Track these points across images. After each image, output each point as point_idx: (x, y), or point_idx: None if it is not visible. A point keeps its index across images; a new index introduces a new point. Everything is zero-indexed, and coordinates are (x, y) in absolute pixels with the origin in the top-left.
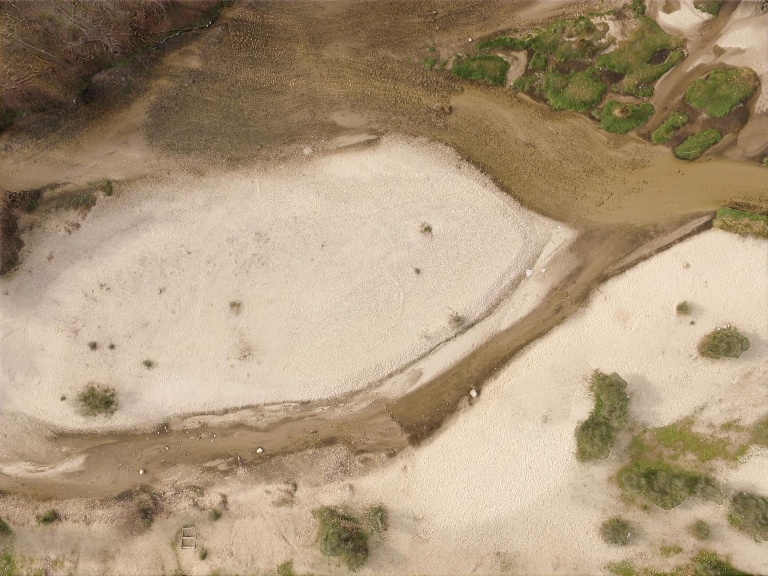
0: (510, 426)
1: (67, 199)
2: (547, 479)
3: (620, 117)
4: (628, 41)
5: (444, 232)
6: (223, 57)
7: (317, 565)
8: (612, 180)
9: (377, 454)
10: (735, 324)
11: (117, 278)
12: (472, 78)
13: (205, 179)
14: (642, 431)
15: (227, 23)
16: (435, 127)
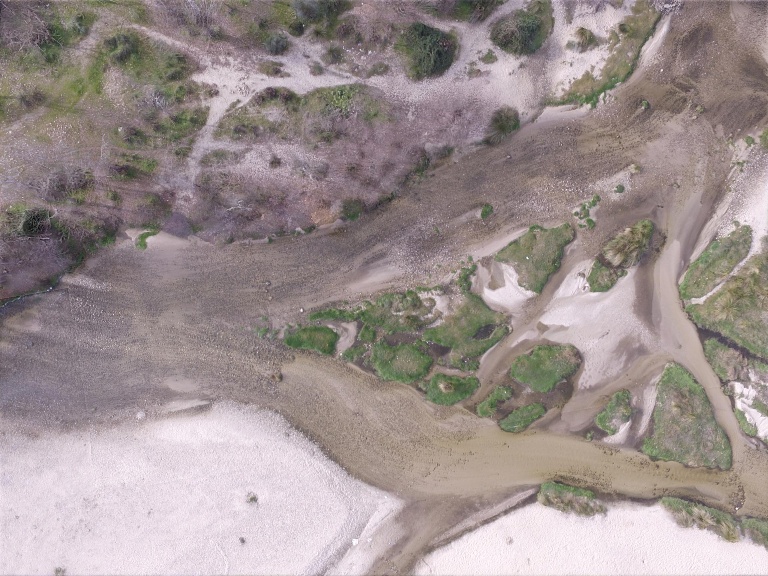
0: None
1: None
2: None
3: None
4: (453, 317)
5: (270, 502)
6: (62, 321)
7: None
8: (438, 451)
9: None
10: None
11: None
12: (302, 348)
13: (39, 440)
14: None
15: (67, 289)
16: (266, 394)
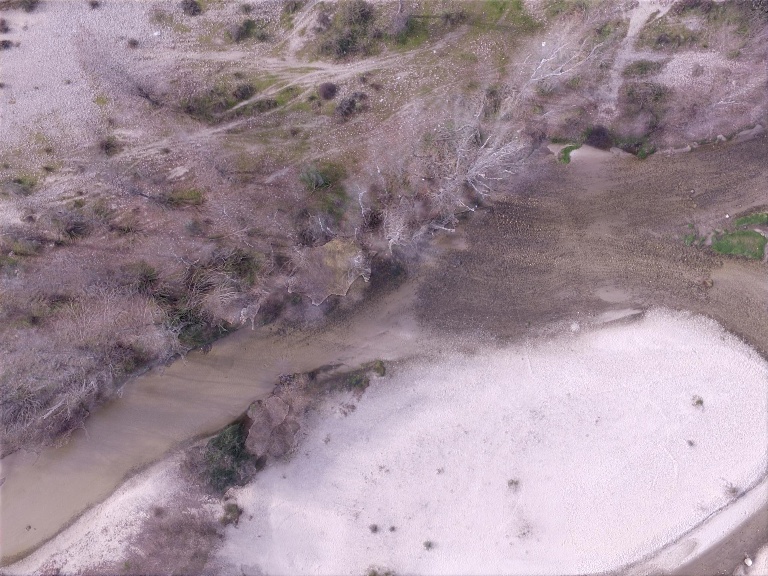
0: None
1: (340, 380)
2: None
3: None
4: None
5: (715, 404)
6: (489, 239)
7: None
8: None
9: None
10: None
11: (396, 460)
12: (731, 253)
13: (476, 357)
14: None
15: (492, 206)
16: (697, 300)
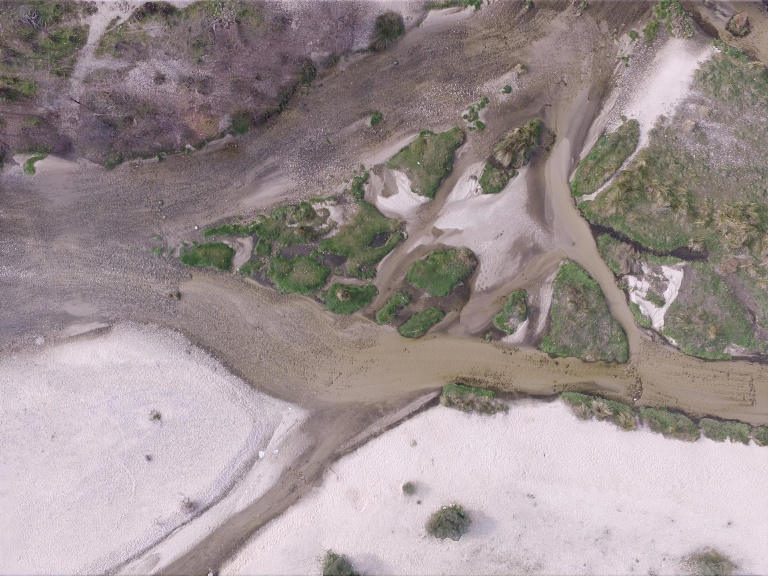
0: None
1: None
2: None
3: (343, 300)
4: (347, 226)
5: (173, 419)
6: None
7: None
8: (340, 360)
9: None
10: (460, 502)
11: None
12: (199, 265)
13: None
14: None
15: None
16: (165, 313)
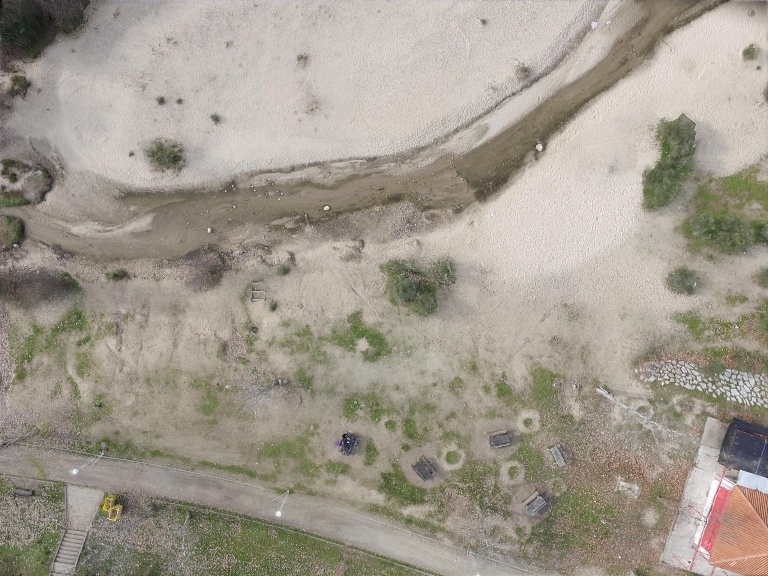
0: (577, 177)
1: None
2: (614, 230)
3: None
4: None
5: None
6: None
7: (387, 314)
8: None
9: (444, 210)
10: None
11: (184, 32)
12: None
13: None
14: (708, 181)
15: None
16: None
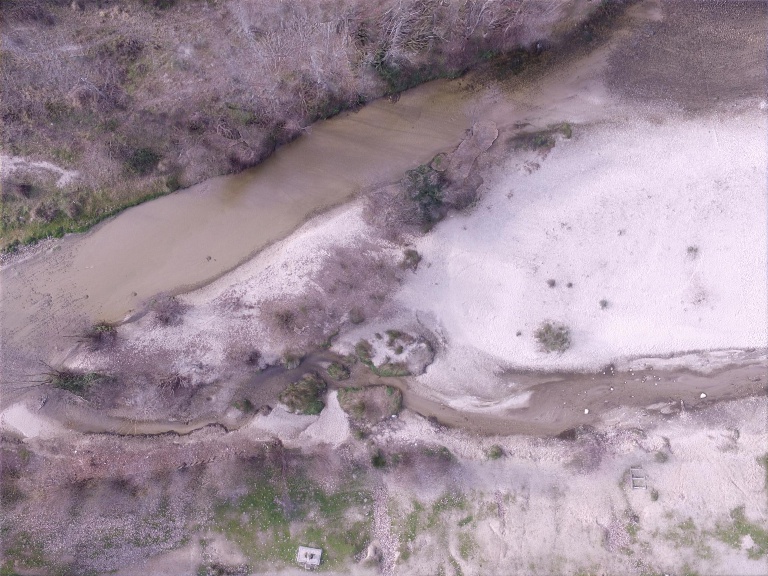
0: None
1: (525, 140)
2: None
3: None
4: None
5: None
6: (685, 11)
7: None
8: None
9: None
10: None
11: (578, 218)
12: None
13: (662, 127)
14: None
15: None
16: None
